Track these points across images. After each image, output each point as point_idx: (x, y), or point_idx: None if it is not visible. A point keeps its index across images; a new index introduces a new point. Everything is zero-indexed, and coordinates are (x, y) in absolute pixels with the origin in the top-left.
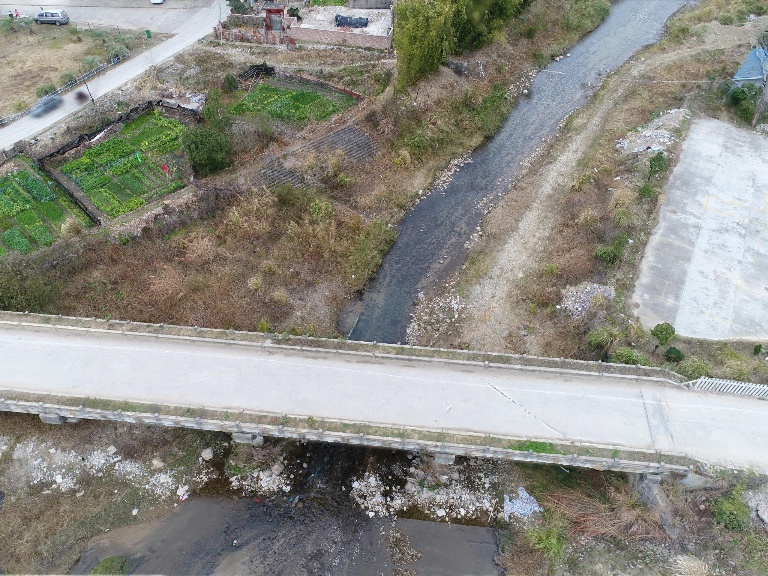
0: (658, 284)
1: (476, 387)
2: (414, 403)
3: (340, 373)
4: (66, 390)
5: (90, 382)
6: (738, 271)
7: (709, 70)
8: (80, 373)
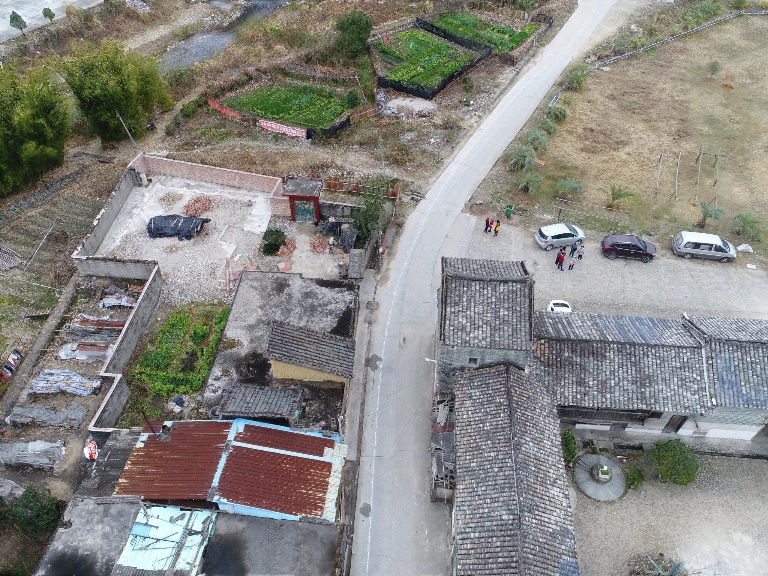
0: None
1: None
2: None
3: None
4: None
5: None
6: (43, 2)
7: None
8: None
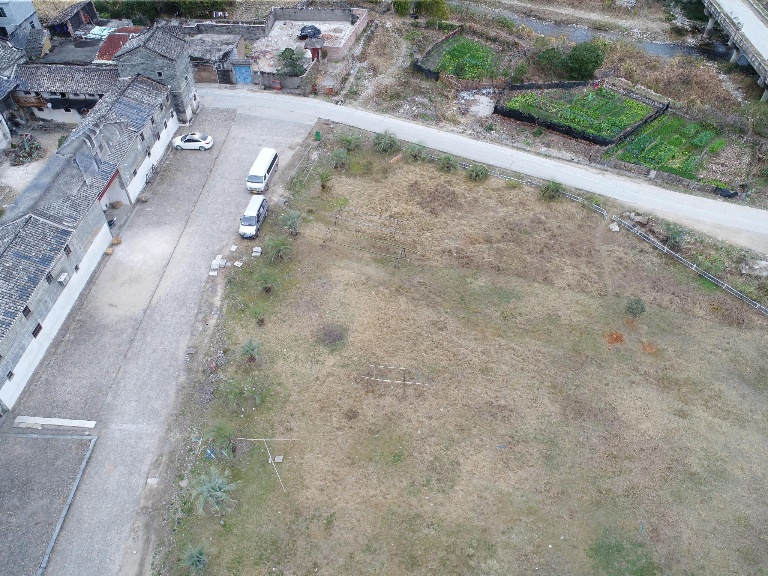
0: None
1: (723, 1)
2: None
3: (740, 22)
4: None
5: None
6: None
7: None
8: None
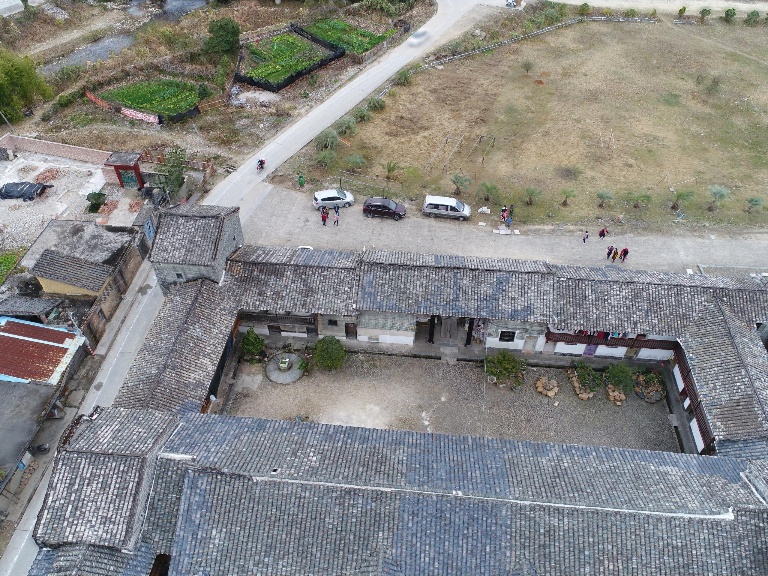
0: (19, 7)
1: None
2: None
3: None
4: None
5: None
6: None
7: None
8: None
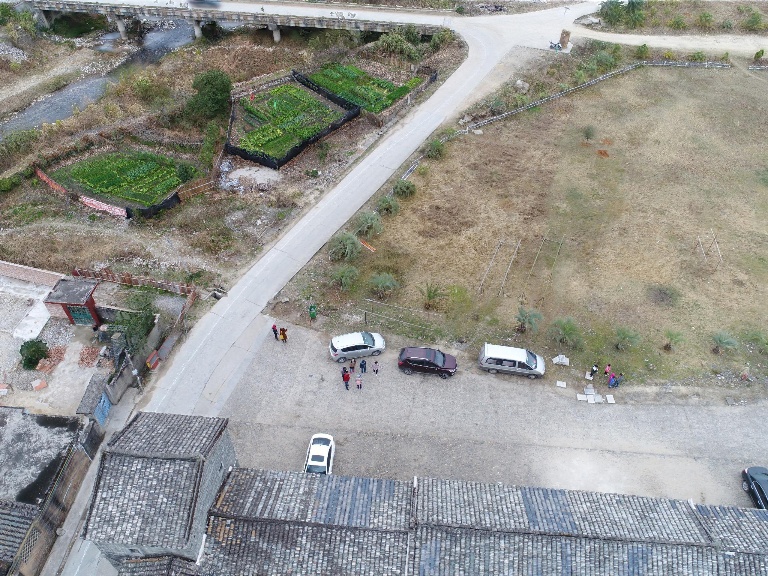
0: None
1: None
2: (136, 0)
3: None
4: (279, 6)
5: (270, 7)
6: None
7: None
8: (275, 9)
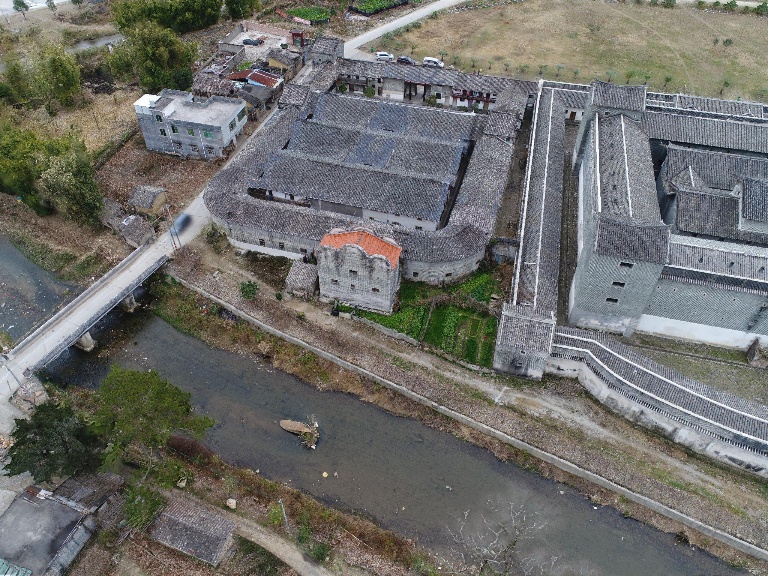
0: None
1: None
2: None
3: None
4: None
5: None
6: None
7: (117, 1)
8: None
